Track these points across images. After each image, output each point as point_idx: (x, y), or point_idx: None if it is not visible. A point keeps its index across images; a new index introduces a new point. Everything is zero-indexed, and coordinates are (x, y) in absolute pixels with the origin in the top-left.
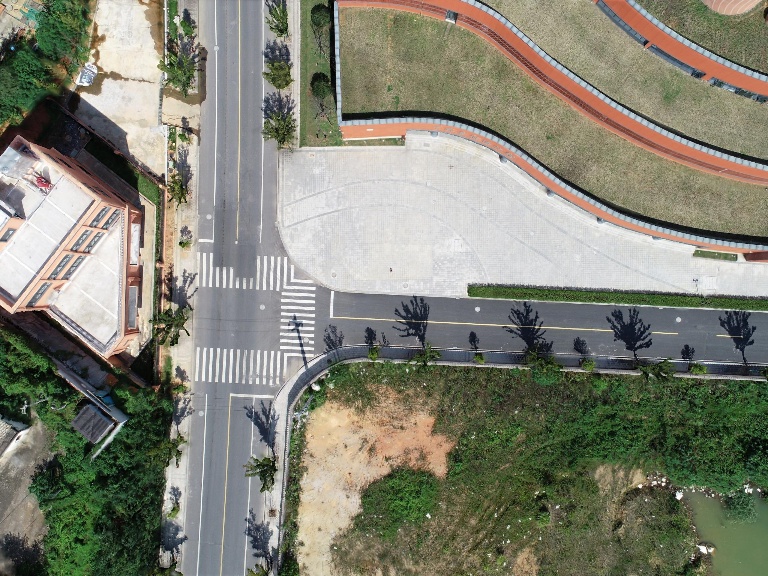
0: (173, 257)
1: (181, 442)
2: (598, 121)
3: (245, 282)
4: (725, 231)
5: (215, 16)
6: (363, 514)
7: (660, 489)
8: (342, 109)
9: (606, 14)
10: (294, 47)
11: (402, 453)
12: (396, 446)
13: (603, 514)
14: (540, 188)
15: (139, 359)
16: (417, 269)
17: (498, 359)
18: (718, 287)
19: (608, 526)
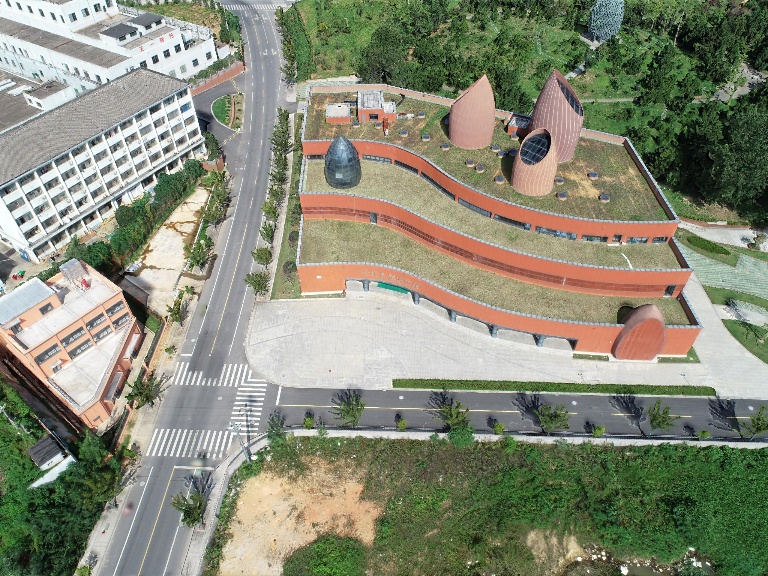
0: (157, 365)
1: (117, 493)
2: (473, 263)
3: (210, 381)
4: None
5: (227, 241)
6: None
7: (602, 563)
8: None
9: (465, 206)
10: (275, 253)
11: (330, 519)
12: (324, 512)
13: None
14: (445, 318)
15: (102, 438)
16: (351, 370)
17: None
18: (600, 379)
19: None
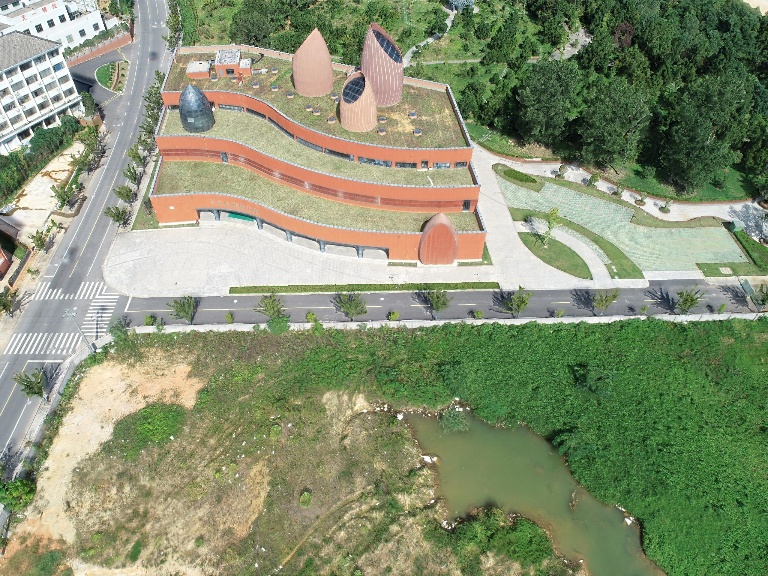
0: (21, 285)
1: None
2: (306, 191)
3: (68, 296)
4: None
5: (98, 185)
6: (112, 440)
7: (383, 413)
8: None
9: (302, 144)
10: (141, 193)
11: (159, 392)
12: (155, 388)
13: (330, 429)
14: (283, 239)
15: None
16: (195, 282)
17: None
18: (407, 280)
19: (335, 438)
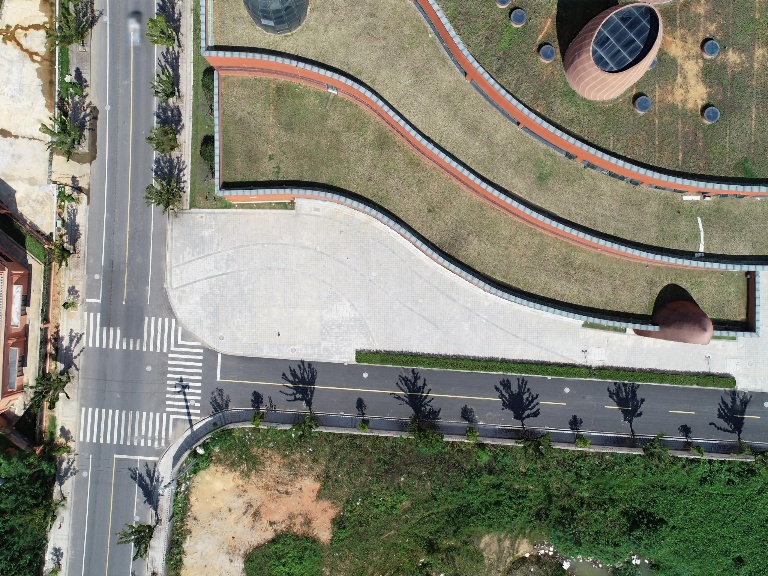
0: (60, 316)
1: (59, 505)
2: (478, 196)
3: (132, 343)
4: (605, 308)
5: (107, 75)
6: None
7: (547, 558)
8: (222, 177)
9: (480, 93)
10: (186, 108)
11: (286, 518)
12: (281, 511)
13: None
14: None
15: (23, 418)
16: (305, 334)
17: (385, 426)
18: (607, 358)
19: None
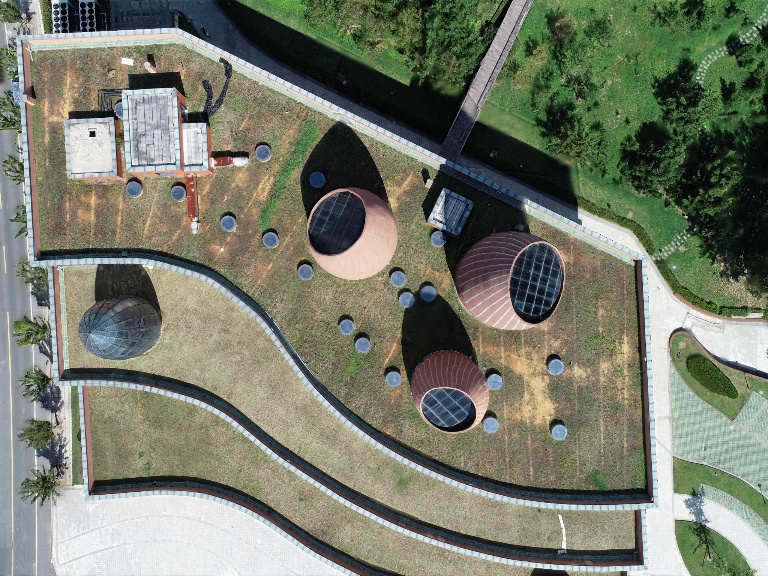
0: None
1: None
2: None
3: None
4: None
5: None
6: None
7: None
8: (94, 476)
9: None
10: None
11: None
12: None
13: None
14: None
15: None
16: None
17: None
18: None
19: None
